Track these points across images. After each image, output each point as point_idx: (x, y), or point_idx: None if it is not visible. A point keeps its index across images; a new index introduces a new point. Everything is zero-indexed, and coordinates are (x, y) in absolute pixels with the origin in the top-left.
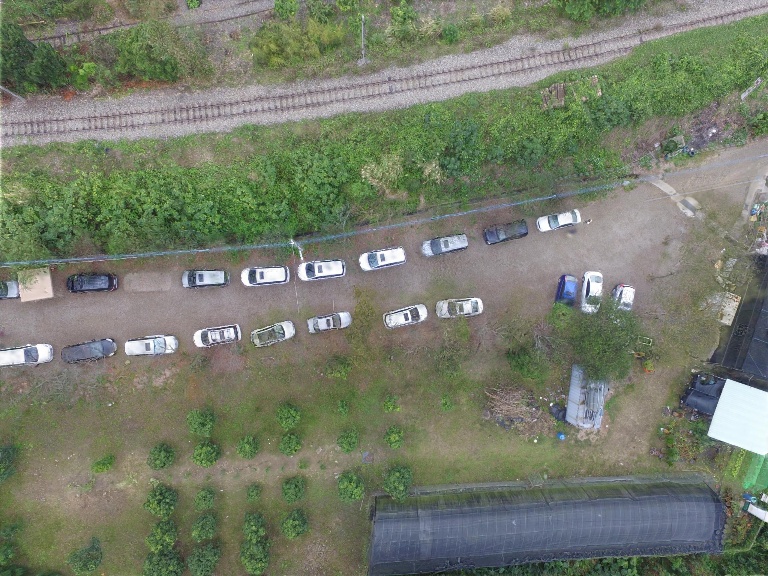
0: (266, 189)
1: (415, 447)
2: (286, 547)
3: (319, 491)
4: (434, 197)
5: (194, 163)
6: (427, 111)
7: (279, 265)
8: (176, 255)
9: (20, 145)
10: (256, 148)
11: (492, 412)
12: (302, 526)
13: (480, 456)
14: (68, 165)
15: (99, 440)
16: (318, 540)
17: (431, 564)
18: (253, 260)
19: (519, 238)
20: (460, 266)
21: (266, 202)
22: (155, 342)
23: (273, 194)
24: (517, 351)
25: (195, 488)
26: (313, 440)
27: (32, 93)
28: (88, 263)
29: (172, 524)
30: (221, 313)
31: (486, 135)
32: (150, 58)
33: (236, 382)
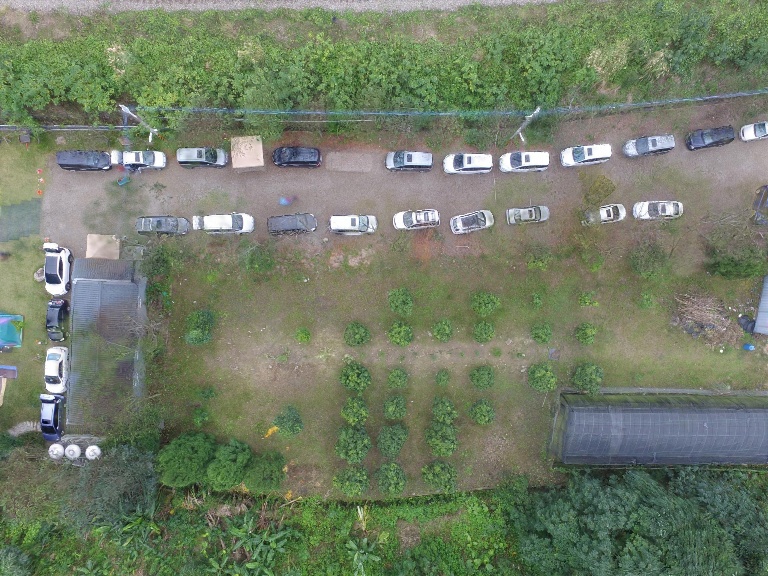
0: (488, 70)
1: (601, 348)
2: (467, 437)
3: (504, 383)
4: (640, 97)
5: (416, 40)
6: (655, 2)
7: None
8: (379, 137)
9: (247, 9)
10: (480, 29)
11: (681, 318)
12: (493, 412)
13: (665, 362)
14: (292, 33)
15: (292, 315)
16: (499, 433)
17: (619, 460)
18: (454, 148)
19: (720, 146)
20: (659, 170)
21: (484, 84)
22: (360, 218)
23: (492, 77)
24: (730, 249)
25: (384, 370)
26: (502, 332)
27: None
28: (292, 139)
29: (364, 401)
30: (419, 198)
31: (710, 32)
32: None
33: (430, 268)
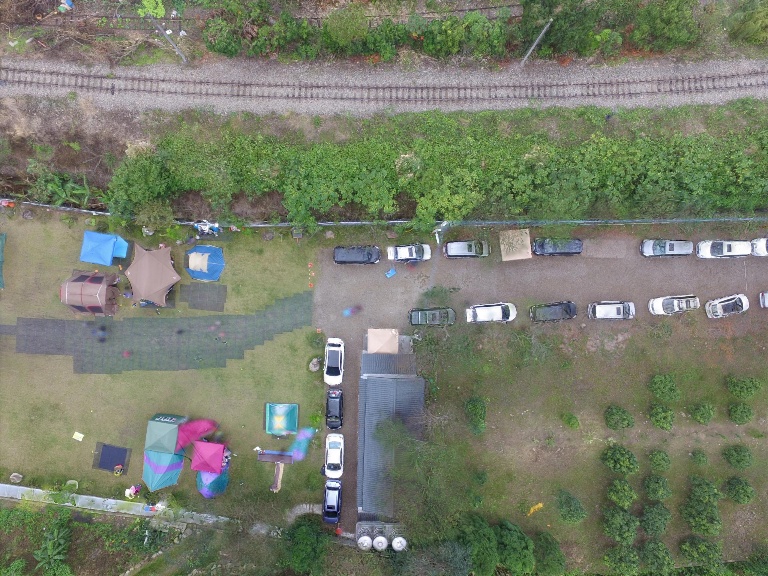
0: (759, 163)
1: None
2: (719, 512)
3: (754, 461)
4: None
5: (685, 134)
6: None
7: (733, 239)
8: (632, 224)
9: (522, 108)
10: (749, 122)
11: None
12: None
13: None
14: (564, 130)
15: (551, 398)
16: (748, 507)
17: None
18: (705, 233)
19: None
20: None
21: (751, 176)
22: (624, 307)
23: (759, 168)
24: None
25: (640, 450)
26: None
27: (532, 57)
28: None
29: None
30: (672, 283)
31: None
32: (686, 27)
33: (683, 351)
